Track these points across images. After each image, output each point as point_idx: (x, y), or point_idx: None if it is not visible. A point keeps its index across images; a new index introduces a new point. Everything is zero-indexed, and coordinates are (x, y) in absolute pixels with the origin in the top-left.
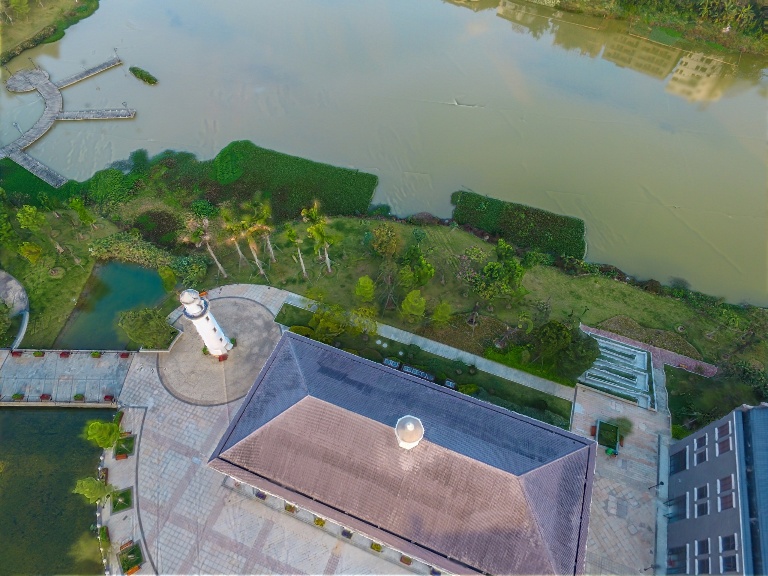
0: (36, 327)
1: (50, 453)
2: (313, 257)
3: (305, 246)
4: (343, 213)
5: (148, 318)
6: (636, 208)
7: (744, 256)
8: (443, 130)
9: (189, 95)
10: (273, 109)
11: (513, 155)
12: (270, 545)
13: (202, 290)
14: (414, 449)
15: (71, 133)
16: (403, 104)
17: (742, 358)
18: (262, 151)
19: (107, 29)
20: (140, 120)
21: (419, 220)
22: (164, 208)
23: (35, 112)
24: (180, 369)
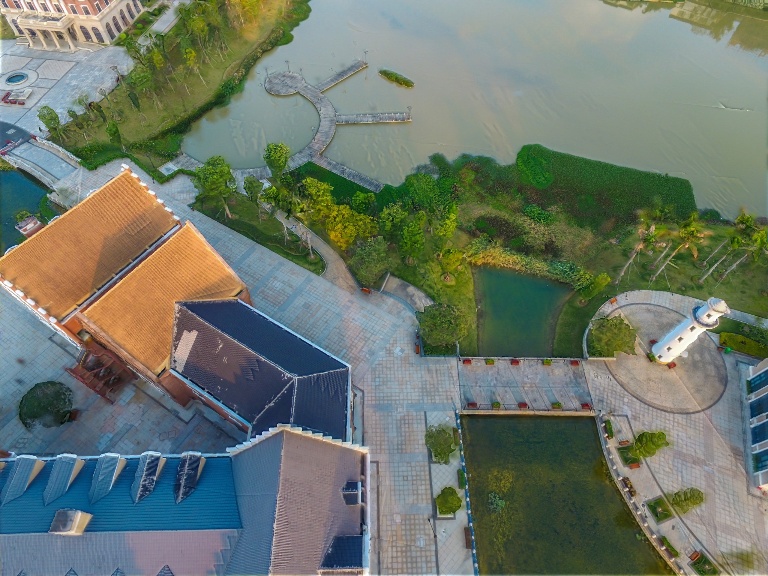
0: None
1: (549, 462)
2: (692, 263)
3: (671, 251)
4: (677, 218)
5: None
6: None
7: None
8: (726, 134)
9: (453, 98)
10: (545, 112)
11: None
12: None
13: (606, 296)
14: None
15: (358, 137)
16: (671, 107)
17: None
18: (561, 155)
19: (333, 31)
20: (414, 123)
21: (764, 225)
22: (497, 213)
23: (309, 115)
24: (635, 376)
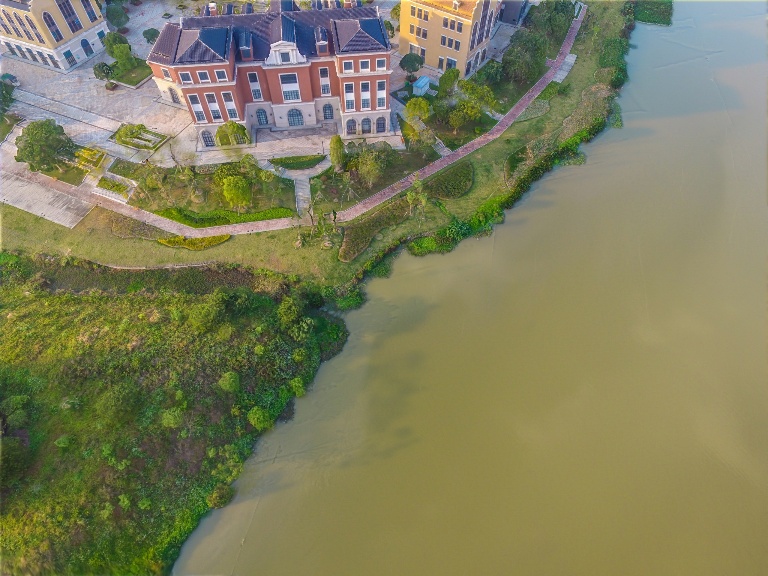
0: None
1: None
2: None
3: None
4: None
5: None
6: (696, 46)
7: (671, 73)
8: None
9: None
10: None
11: (722, 11)
12: None
13: None
14: None
15: None
16: None
17: (584, 44)
18: None
19: None
20: None
21: None
22: None
23: None
24: None
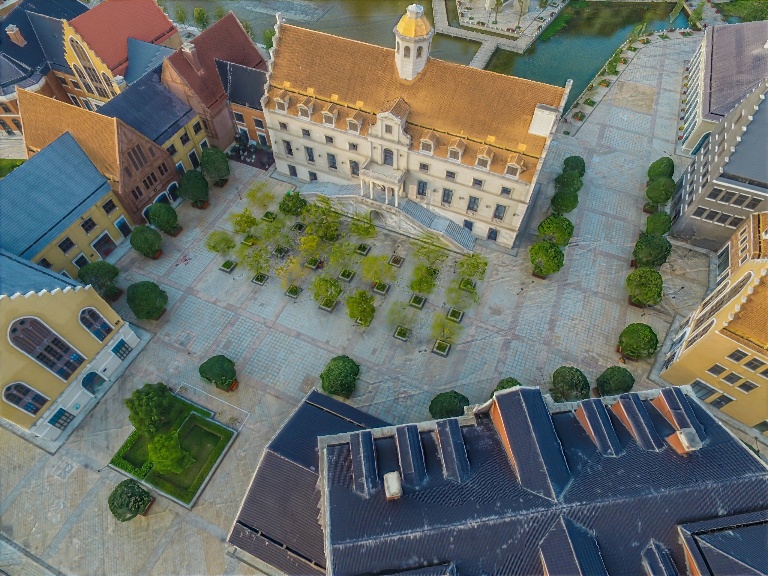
0: (724, 6)
1: None
2: None
3: None
4: None
5: (762, 12)
6: None
7: None
8: None
9: None
10: None
11: None
12: (668, 74)
13: None
14: (766, 48)
15: None
16: None
17: None
18: None
19: None
20: None
21: None
22: None
23: None
24: None
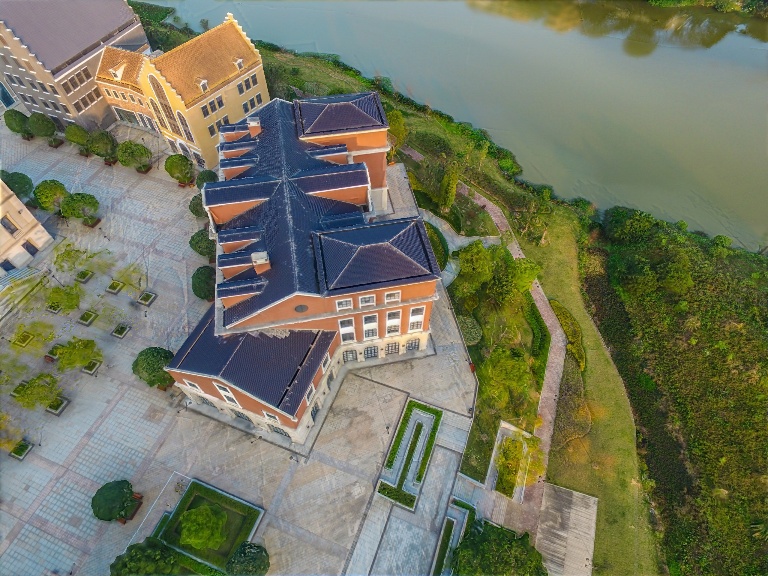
0: None
1: None
2: None
3: None
4: None
5: None
6: (215, 4)
7: (259, 22)
8: None
9: None
10: None
11: None
12: None
13: None
14: None
15: None
16: None
17: None
18: None
19: None
20: None
21: None
22: None
23: None
24: None
